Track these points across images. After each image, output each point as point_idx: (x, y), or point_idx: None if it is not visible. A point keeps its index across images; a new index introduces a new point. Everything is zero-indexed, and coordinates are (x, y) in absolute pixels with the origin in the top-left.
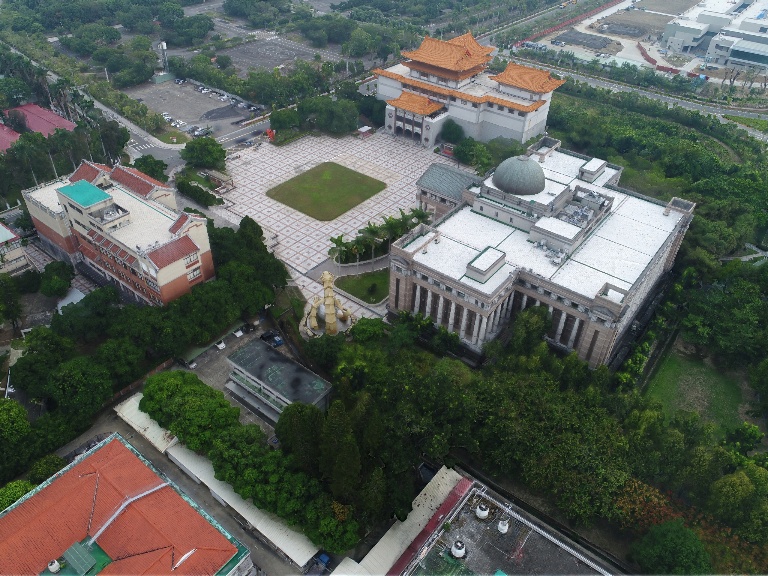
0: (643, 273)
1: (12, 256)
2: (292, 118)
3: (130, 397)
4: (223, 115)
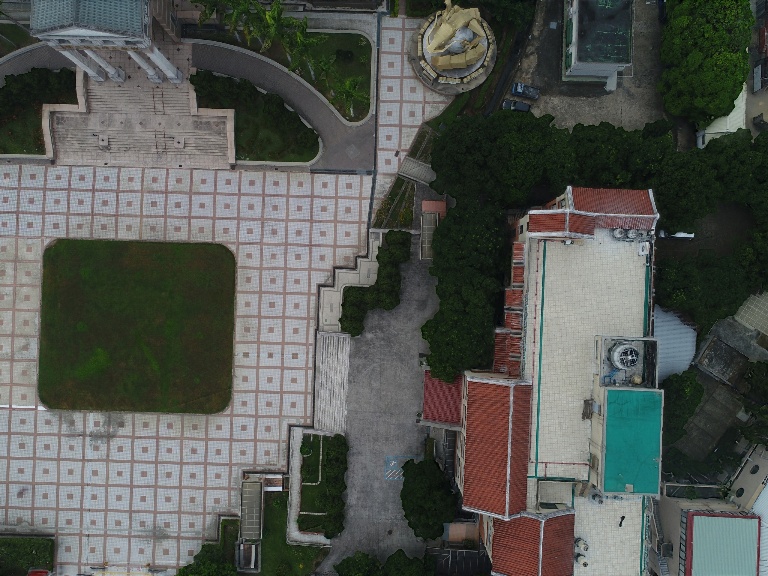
0: None
1: (694, 507)
2: None
3: None
4: None
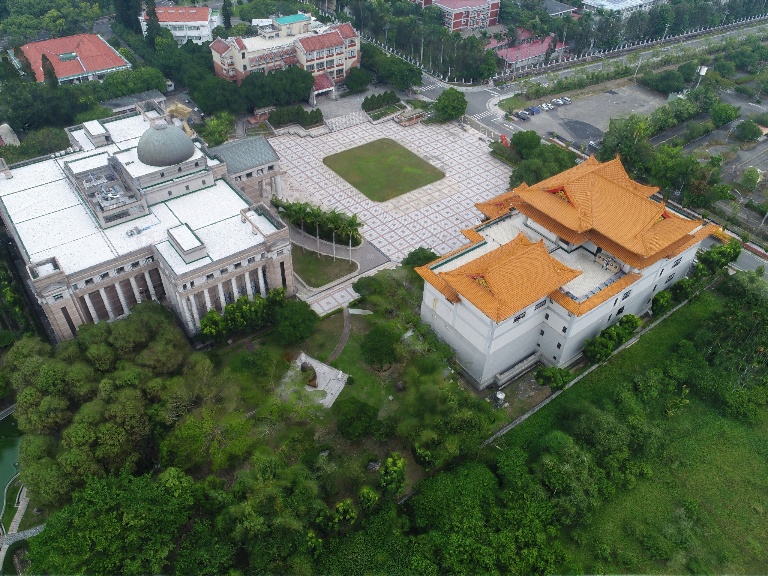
0: (0, 201)
1: None
2: (523, 144)
3: (172, 82)
4: (577, 130)
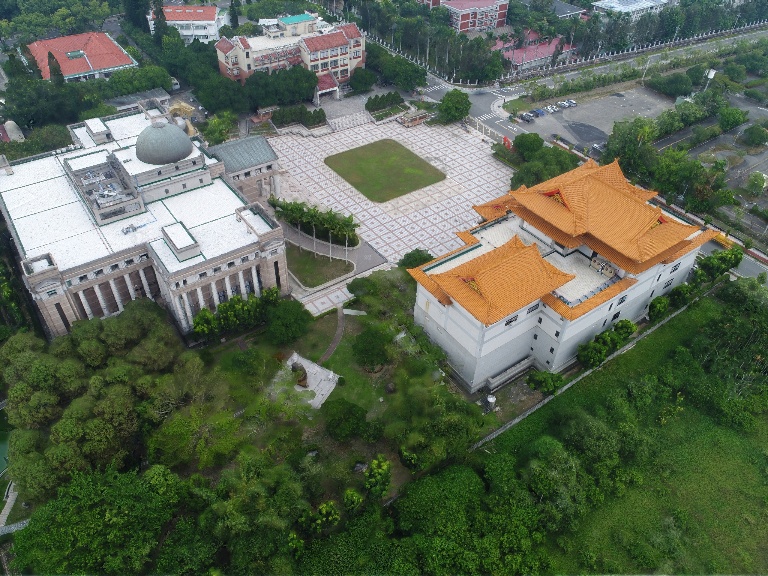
0: None
1: None
2: (526, 146)
3: (177, 80)
4: (581, 132)
